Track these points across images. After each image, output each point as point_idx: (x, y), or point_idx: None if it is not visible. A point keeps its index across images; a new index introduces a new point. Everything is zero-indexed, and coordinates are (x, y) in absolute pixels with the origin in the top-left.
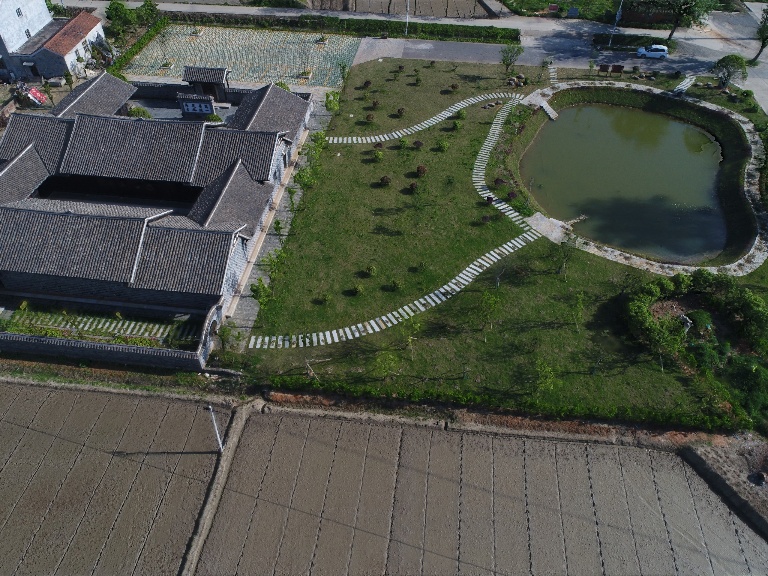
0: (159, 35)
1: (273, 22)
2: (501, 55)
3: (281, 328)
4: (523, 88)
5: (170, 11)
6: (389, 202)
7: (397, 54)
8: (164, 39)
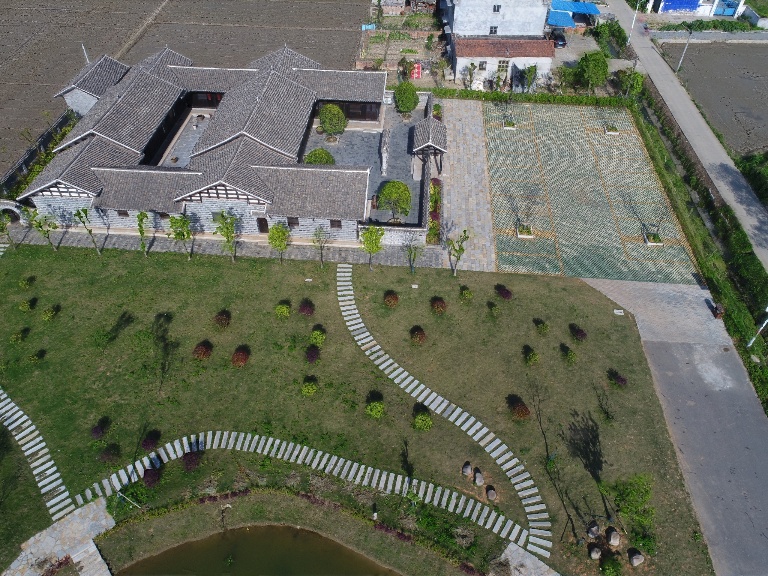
0: (592, 107)
1: (700, 186)
2: (749, 526)
3: (8, 260)
4: (582, 558)
5: (665, 102)
6: (183, 330)
7: (655, 333)
8: (583, 112)
